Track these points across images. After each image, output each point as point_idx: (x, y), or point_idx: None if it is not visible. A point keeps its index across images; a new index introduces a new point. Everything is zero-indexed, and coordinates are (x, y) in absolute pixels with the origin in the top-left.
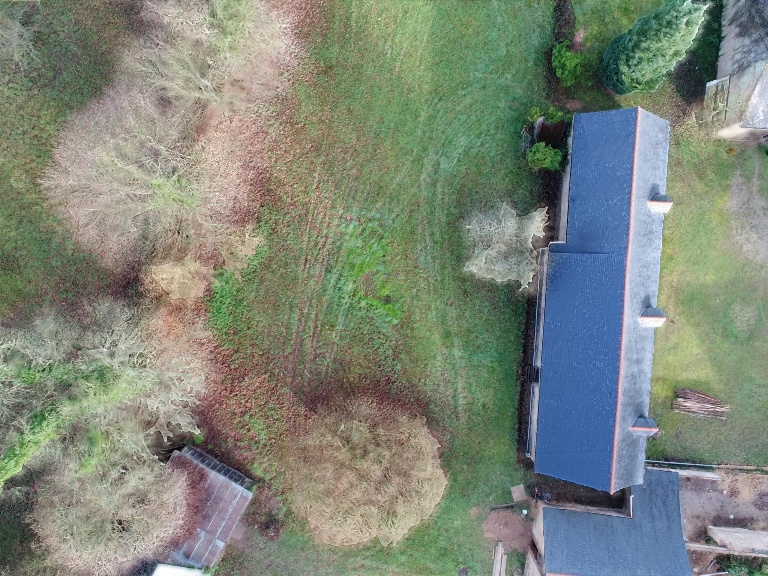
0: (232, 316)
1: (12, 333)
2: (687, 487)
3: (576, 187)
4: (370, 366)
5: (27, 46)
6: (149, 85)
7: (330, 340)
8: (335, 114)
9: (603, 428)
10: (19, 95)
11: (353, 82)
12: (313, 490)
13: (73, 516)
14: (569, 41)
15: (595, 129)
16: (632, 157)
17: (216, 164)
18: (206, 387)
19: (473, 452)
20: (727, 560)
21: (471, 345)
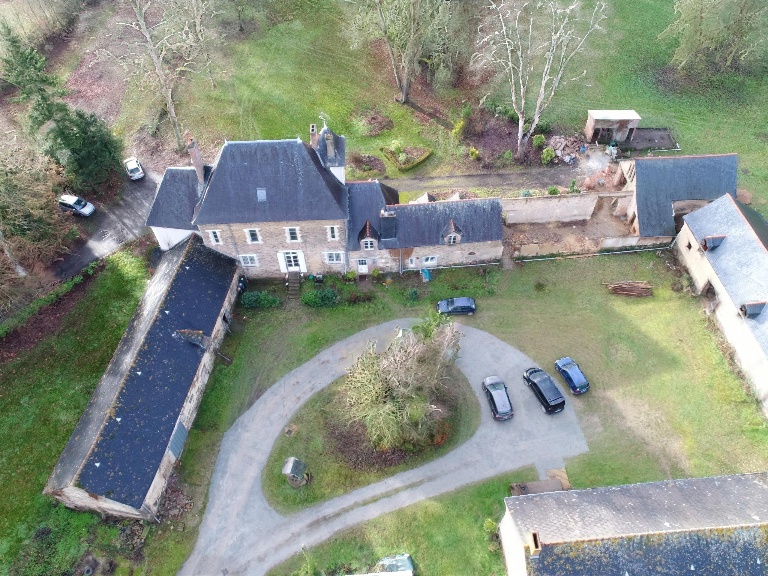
0: None
1: None
2: None
3: None
4: None
5: None
6: None
7: None
8: None
9: None
10: None
11: None
12: None
13: None
14: None
15: None
16: None
17: None
18: None
19: None
20: None
21: None
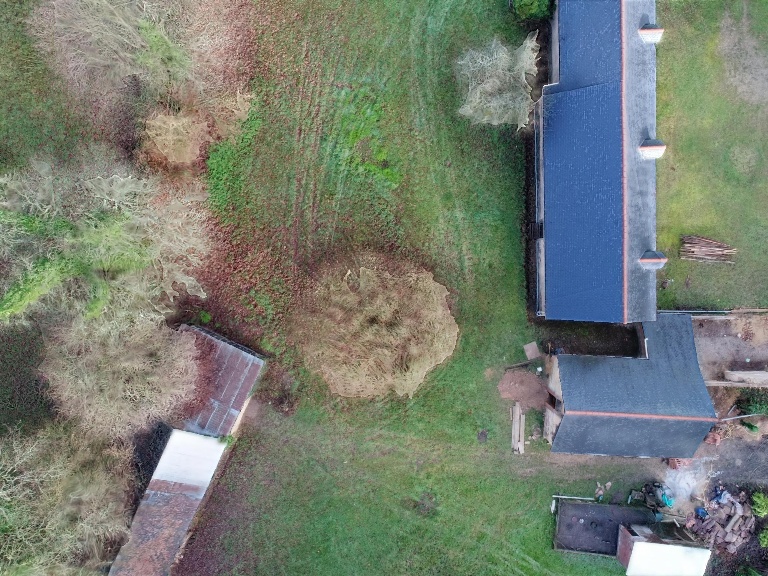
0: (230, 192)
1: (8, 167)
2: (701, 334)
3: (565, 25)
4: (373, 233)
5: None
6: None
7: (330, 209)
8: None
9: (611, 259)
10: None
11: None
12: (324, 336)
13: (83, 365)
14: None
15: None
16: None
17: (202, 27)
18: (209, 266)
19: (483, 313)
20: (747, 403)
21: (473, 205)
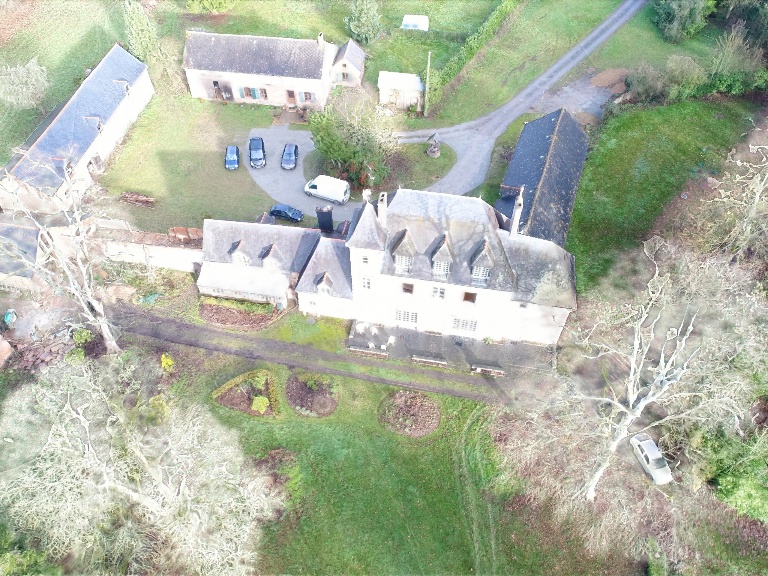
0: None
1: None
2: (108, 238)
3: None
4: None
5: None
6: None
7: None
8: None
9: None
10: None
11: (6, 62)
12: None
13: None
14: None
15: None
16: None
17: None
18: None
19: None
20: None
21: (1, 158)
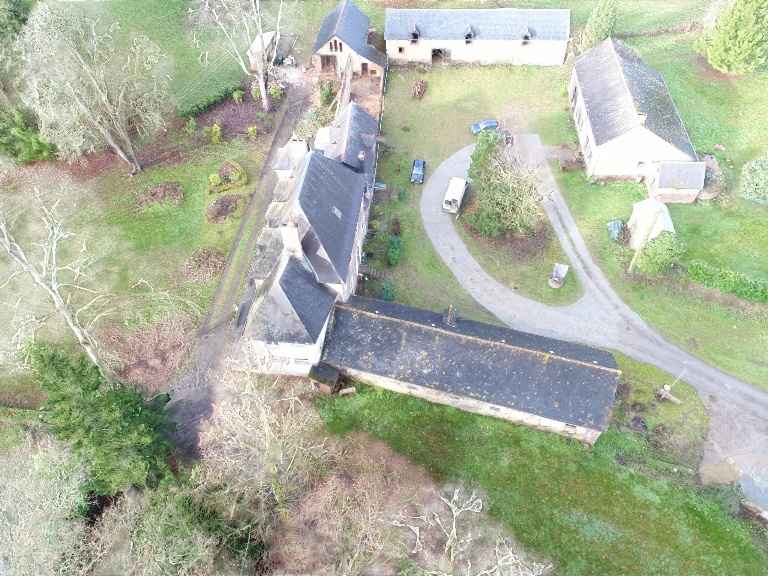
0: None
1: None
2: None
3: None
4: None
5: None
6: None
7: None
8: None
9: None
10: None
11: None
12: None
13: None
14: None
15: None
16: None
17: None
18: None
19: None
20: None
21: None
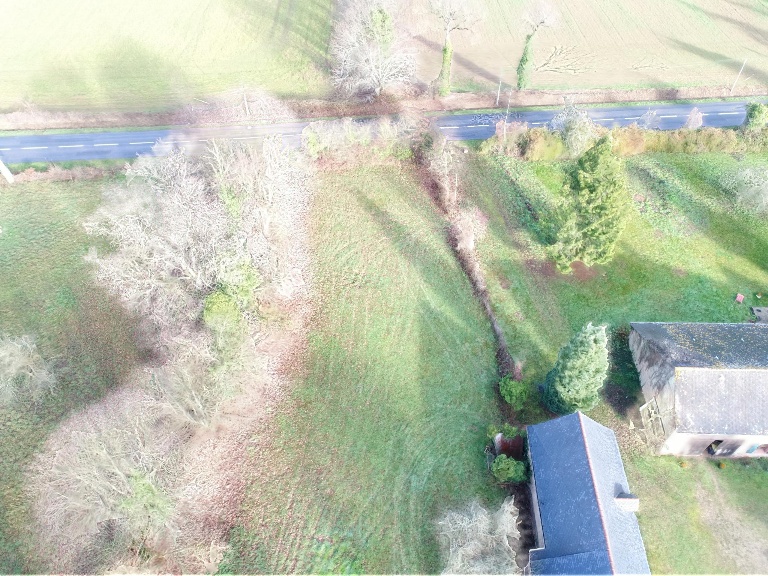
0: None
1: None
2: None
3: (543, 490)
4: None
5: (48, 389)
6: (147, 408)
7: None
8: (312, 440)
9: None
10: (24, 429)
11: (329, 413)
12: None
13: None
14: (511, 374)
15: (547, 436)
16: (585, 453)
17: None
18: None
19: None
20: None
21: None
